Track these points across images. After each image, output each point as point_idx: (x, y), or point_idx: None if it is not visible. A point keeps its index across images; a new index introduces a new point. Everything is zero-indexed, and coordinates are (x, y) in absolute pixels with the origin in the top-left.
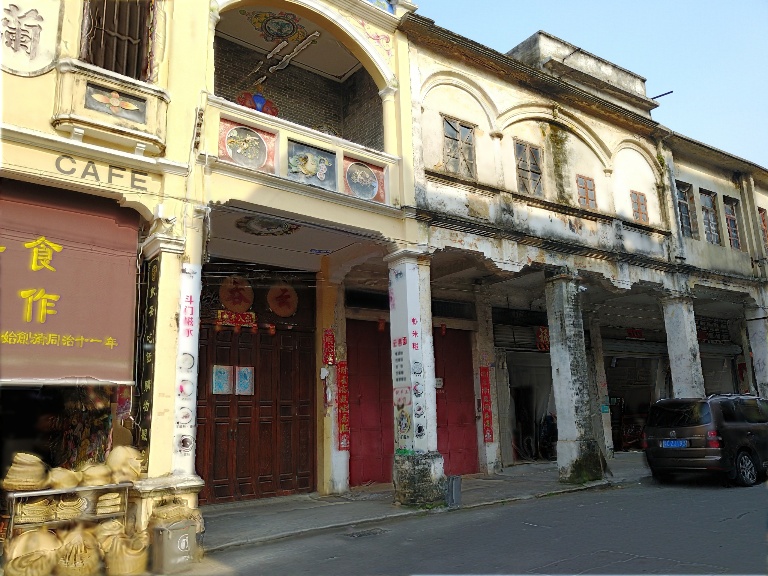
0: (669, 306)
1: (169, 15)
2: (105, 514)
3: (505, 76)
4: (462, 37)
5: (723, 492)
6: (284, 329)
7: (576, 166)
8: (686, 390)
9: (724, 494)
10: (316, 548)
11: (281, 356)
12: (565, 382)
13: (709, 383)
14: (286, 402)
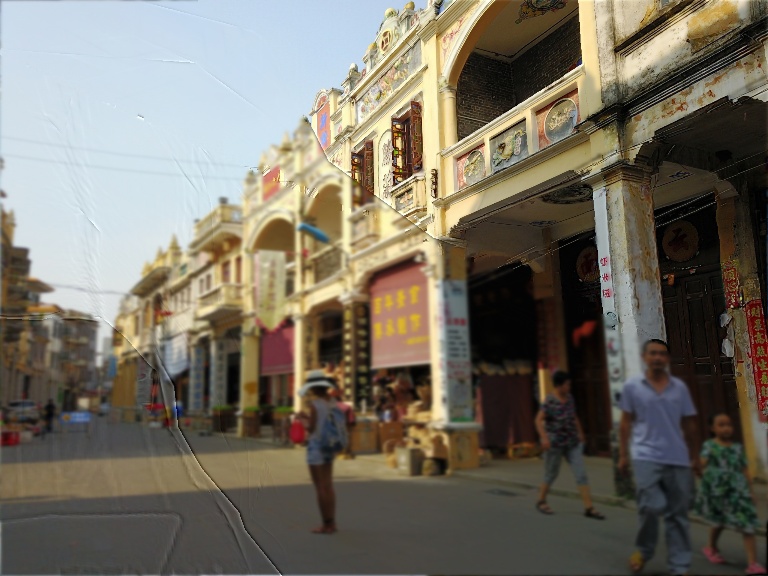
0: None
1: (423, 117)
2: None
3: None
4: None
5: None
6: (687, 275)
7: None
8: None
9: None
10: None
11: (689, 306)
12: None
13: None
14: (703, 359)
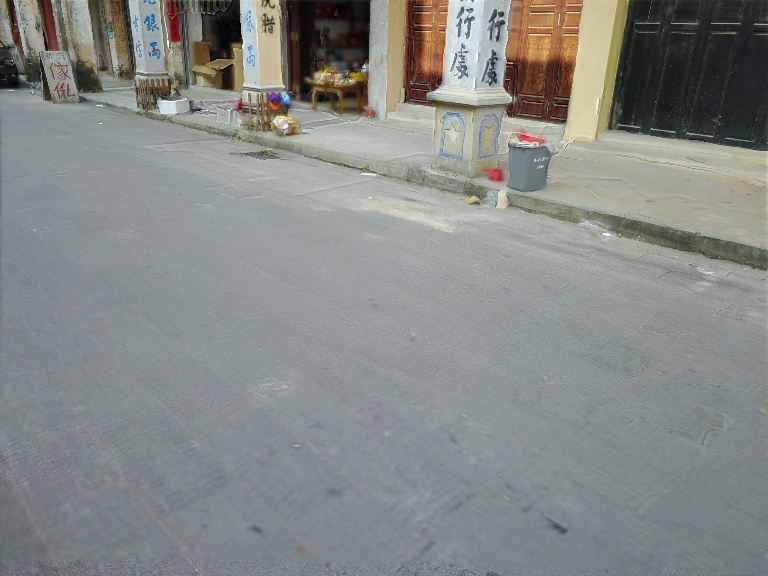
0: None
1: None
2: None
3: None
4: None
5: None
6: None
7: None
8: None
9: None
10: None
11: None
12: None
13: (232, 6)
14: None
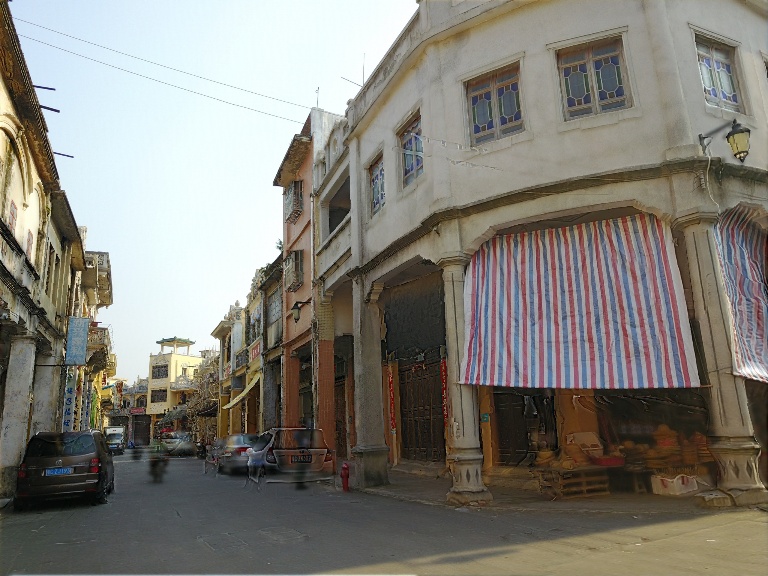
0: (19, 344)
1: None
2: None
3: (5, 78)
4: (14, 27)
5: (103, 508)
6: None
7: (13, 191)
8: (16, 425)
9: None
10: None
11: None
12: None
13: None
14: None
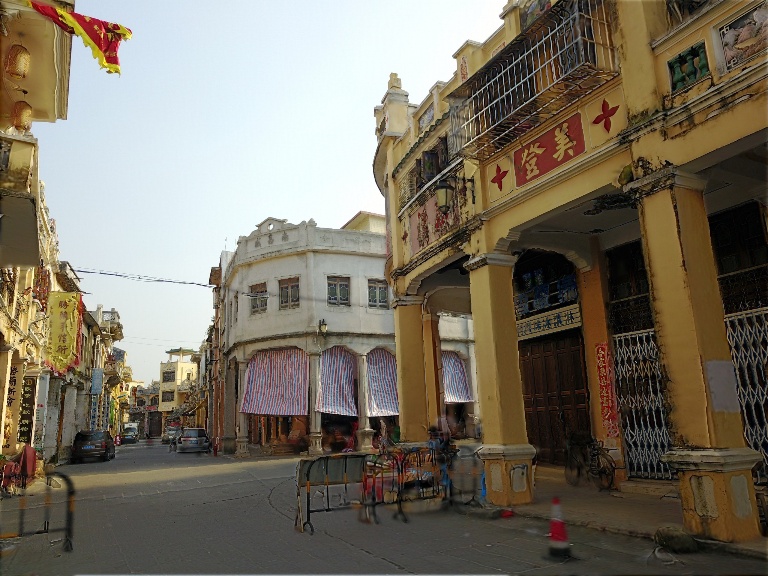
0: (69, 389)
1: None
2: None
3: (64, 288)
4: None
5: None
6: None
7: None
8: (69, 427)
9: (110, 462)
10: None
11: None
12: (54, 423)
13: None
14: None
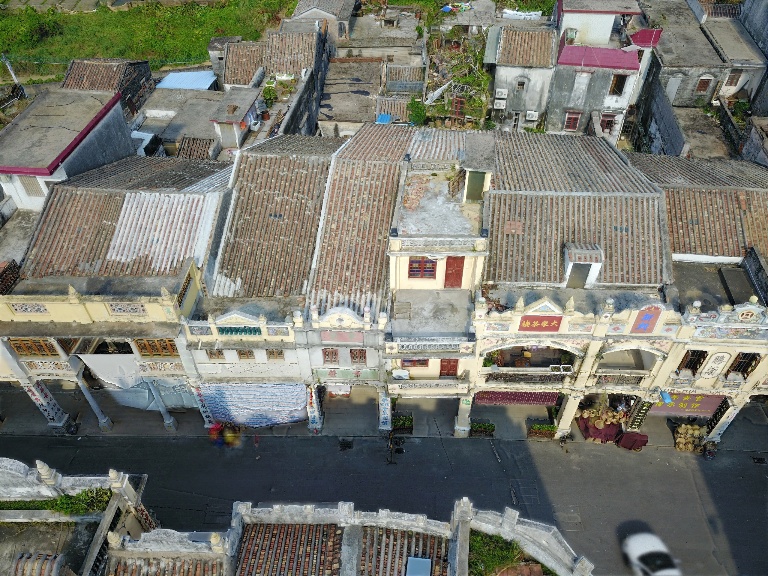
0: None
1: None
2: (696, 437)
3: None
4: None
5: None
6: None
7: None
8: None
9: None
10: (741, 467)
11: None
12: None
13: None
14: None
